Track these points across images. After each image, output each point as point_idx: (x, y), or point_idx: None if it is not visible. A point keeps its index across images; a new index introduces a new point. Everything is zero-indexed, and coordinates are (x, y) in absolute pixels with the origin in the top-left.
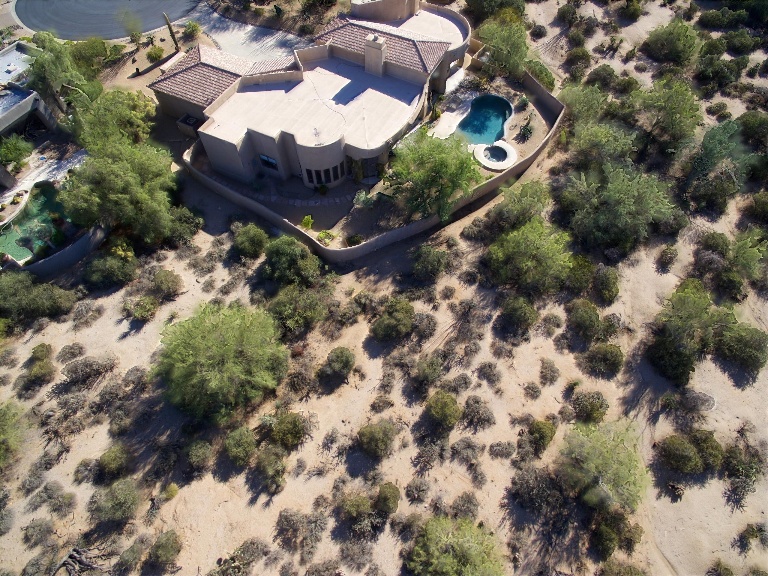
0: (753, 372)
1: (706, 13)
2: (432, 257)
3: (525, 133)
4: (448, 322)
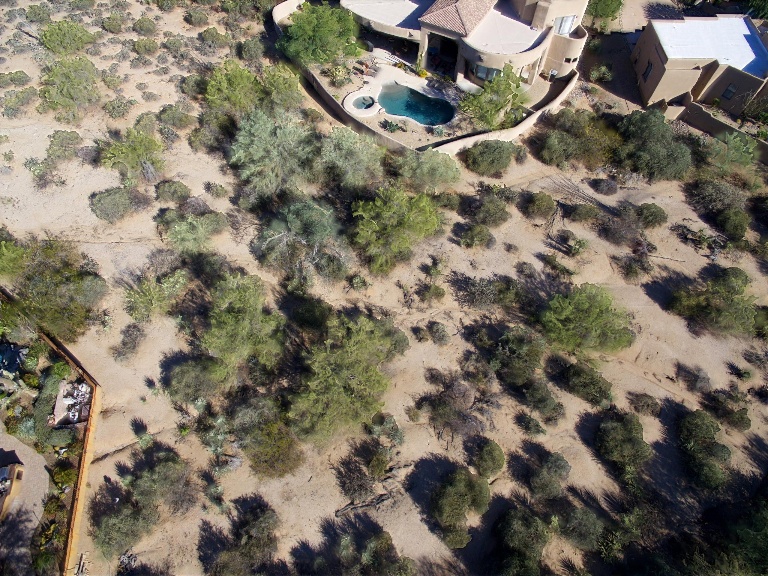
0: None
1: None
2: (248, 42)
3: None
4: None
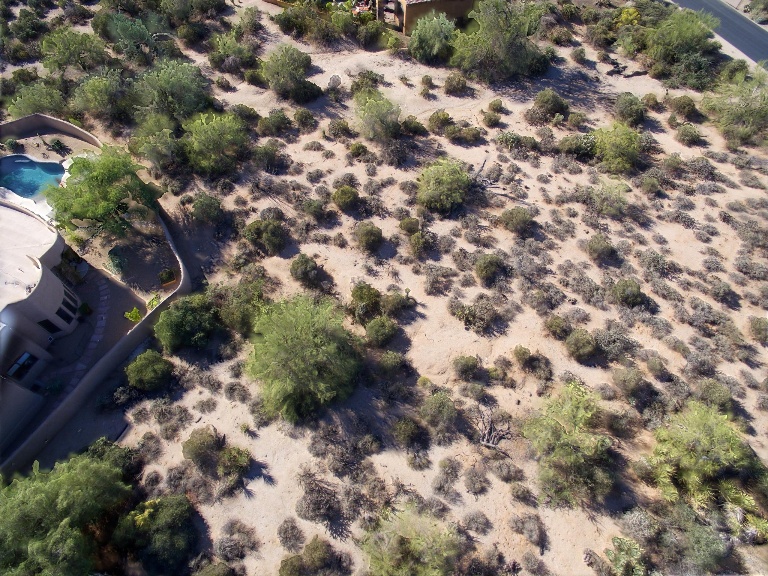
0: (313, 66)
1: None
2: (208, 201)
3: (60, 146)
4: (270, 202)
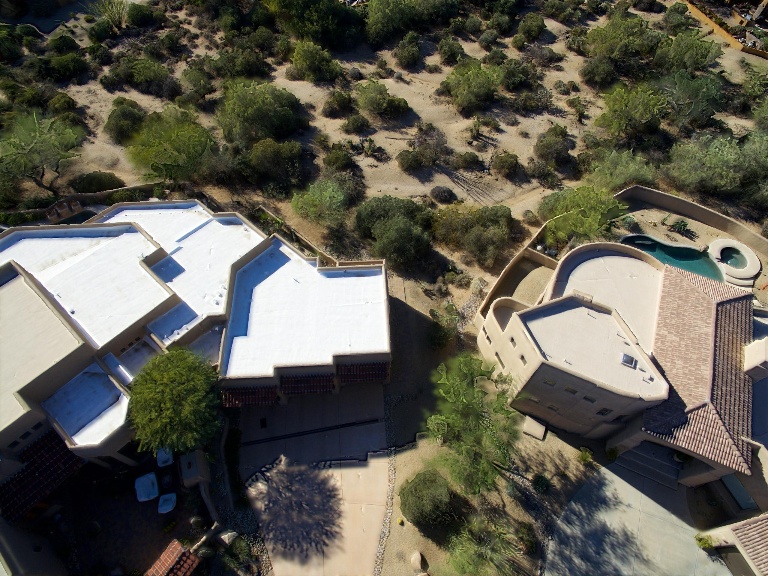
0: None
1: (407, 57)
2: None
3: None
4: None
